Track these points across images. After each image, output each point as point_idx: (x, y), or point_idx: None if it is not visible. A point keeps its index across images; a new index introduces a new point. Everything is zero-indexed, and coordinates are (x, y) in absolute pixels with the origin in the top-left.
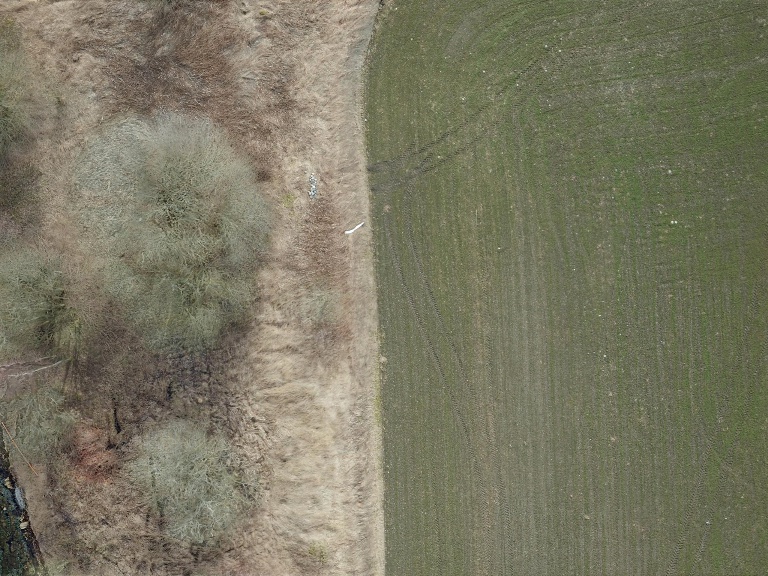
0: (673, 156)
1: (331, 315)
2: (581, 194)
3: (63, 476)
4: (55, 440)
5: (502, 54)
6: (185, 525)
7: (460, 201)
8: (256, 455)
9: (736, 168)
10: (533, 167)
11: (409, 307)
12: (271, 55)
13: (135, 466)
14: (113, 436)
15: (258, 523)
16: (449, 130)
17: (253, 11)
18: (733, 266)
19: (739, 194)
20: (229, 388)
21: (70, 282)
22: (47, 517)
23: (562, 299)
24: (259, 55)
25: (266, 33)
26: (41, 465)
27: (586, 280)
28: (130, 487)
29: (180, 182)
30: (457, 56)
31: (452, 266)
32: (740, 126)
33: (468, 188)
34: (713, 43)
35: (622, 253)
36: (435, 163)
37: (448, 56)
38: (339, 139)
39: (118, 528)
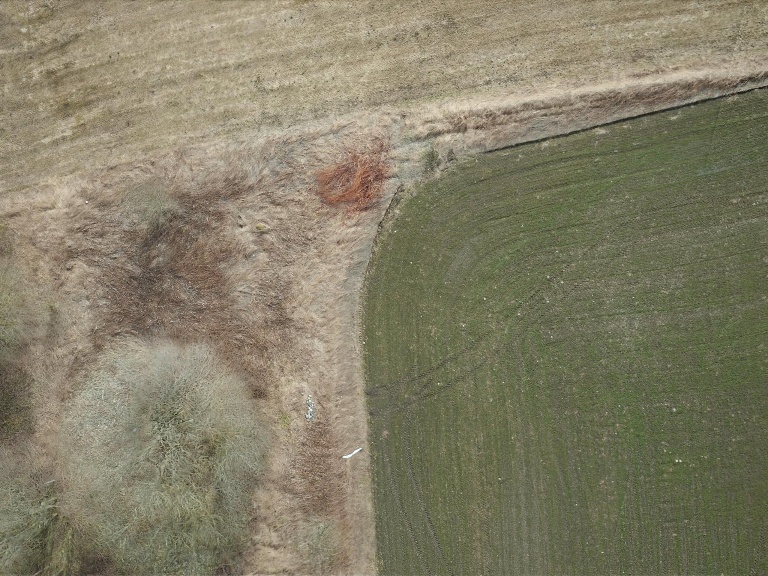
0: (678, 394)
1: (328, 541)
2: (584, 429)
3: None
4: None
5: (503, 282)
6: None
7: (460, 429)
8: None
9: (742, 409)
10: (535, 398)
11: (408, 535)
12: (268, 270)
13: None
14: None
15: None
16: (449, 357)
17: (250, 225)
18: (739, 507)
19: (745, 435)
20: None
21: (63, 490)
22: None
23: (564, 534)
24: (256, 269)
25: (263, 247)
26: None
27: (588, 516)
28: None
29: (175, 396)
30: (457, 282)
31: (452, 495)
32: (746, 366)
33: (468, 417)
34: (719, 281)
35: (625, 490)
36: (435, 390)
37: (448, 281)
38: (337, 362)
39: None
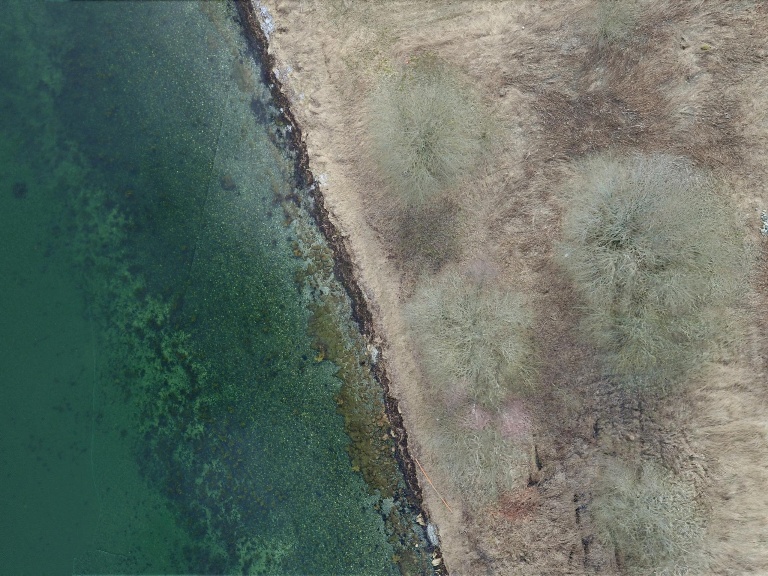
0: None
1: None
2: None
3: (480, 513)
4: (472, 477)
5: None
6: (666, 567)
7: None
8: (692, 493)
9: None
10: None
11: None
12: (712, 90)
13: (558, 503)
14: (535, 473)
15: (693, 561)
16: None
17: (693, 46)
18: None
19: None
20: (664, 425)
21: (488, 318)
22: (462, 554)
23: None
24: (699, 90)
25: (707, 68)
26: (456, 502)
27: None
28: (552, 524)
29: (614, 218)
30: None
31: None
32: None
33: None
34: None
35: None
36: None
37: None
38: None
39: (537, 565)
